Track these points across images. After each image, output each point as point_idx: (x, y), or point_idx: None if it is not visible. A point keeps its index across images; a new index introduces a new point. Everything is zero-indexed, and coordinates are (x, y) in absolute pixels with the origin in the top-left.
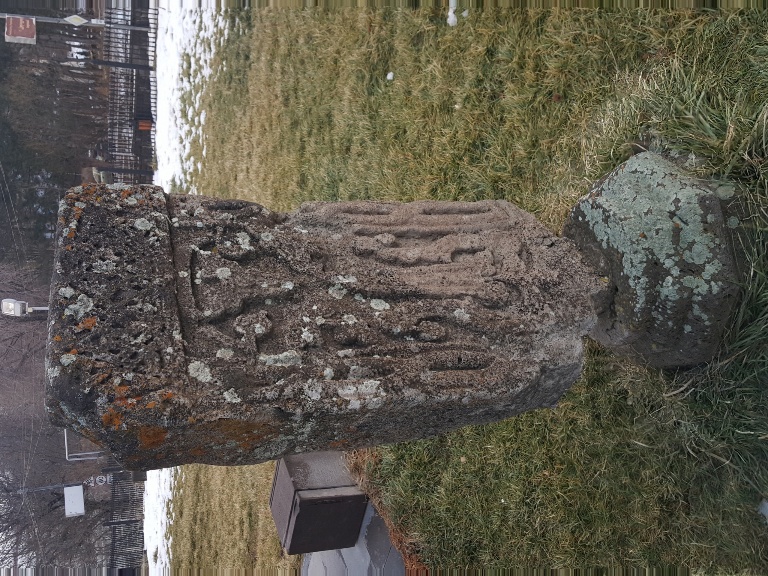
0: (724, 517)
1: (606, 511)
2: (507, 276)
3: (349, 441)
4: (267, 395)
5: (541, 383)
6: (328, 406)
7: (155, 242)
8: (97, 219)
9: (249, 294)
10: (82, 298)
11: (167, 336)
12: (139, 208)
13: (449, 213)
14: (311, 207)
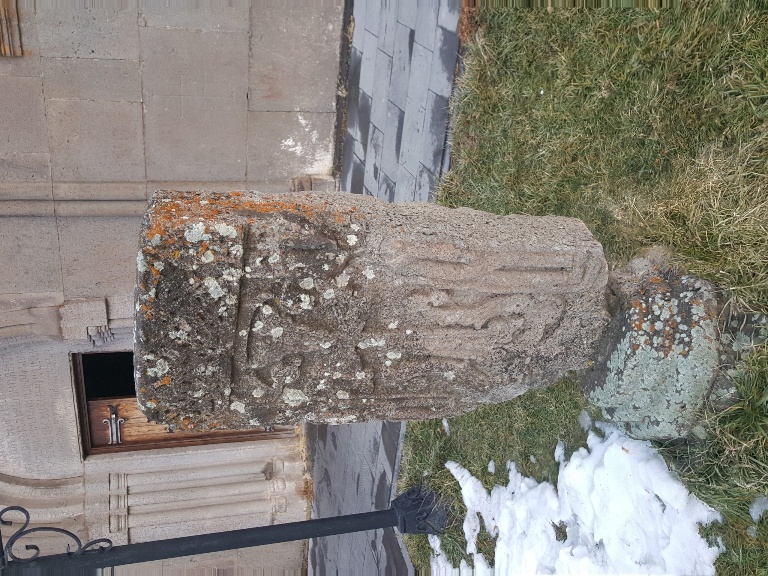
0: None
1: None
2: None
3: None
4: None
5: None
6: None
7: (224, 313)
8: (174, 285)
9: (291, 352)
10: (160, 362)
11: (220, 393)
12: (215, 263)
13: None
14: (390, 253)
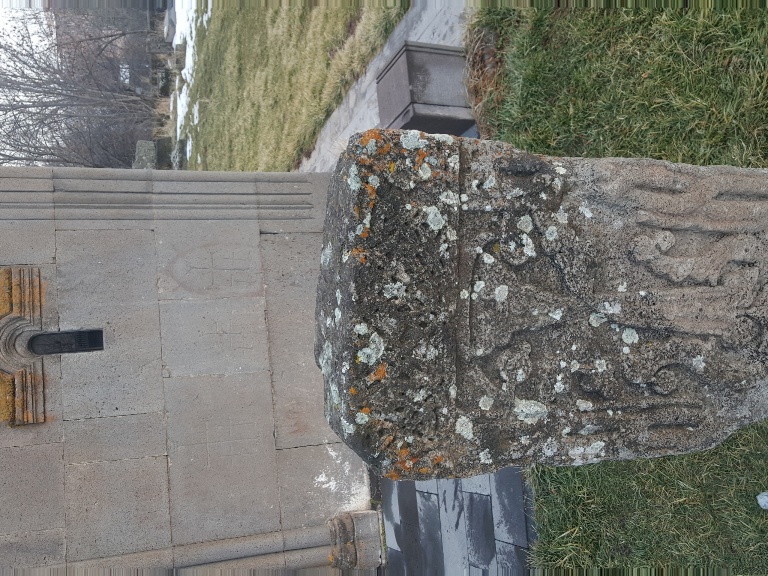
0: None
1: None
2: (760, 313)
3: None
4: (513, 457)
5: None
6: (557, 464)
7: (445, 253)
8: (391, 210)
9: (520, 326)
10: (374, 338)
11: (444, 393)
12: (432, 183)
13: (742, 195)
14: (605, 177)
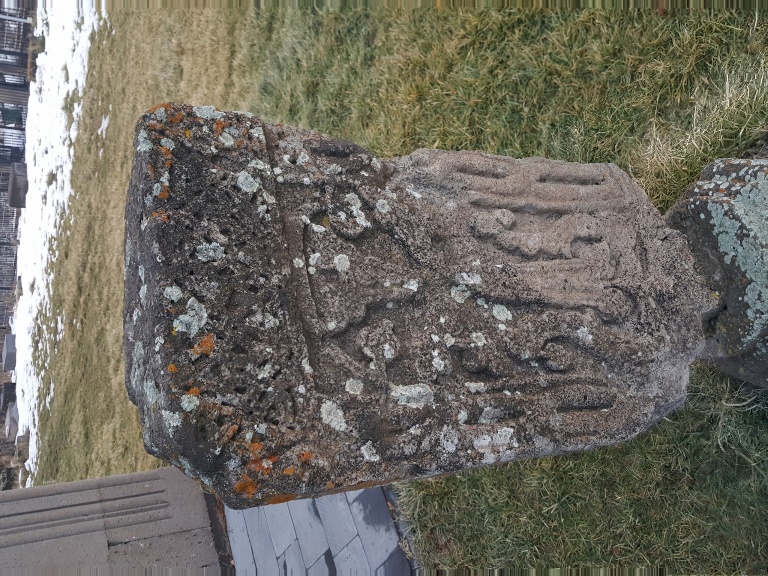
0: (730, 504)
1: (599, 452)
2: (626, 283)
3: None
4: (406, 450)
5: None
6: (463, 461)
7: (265, 214)
8: (192, 171)
9: (373, 297)
10: (192, 304)
11: (297, 367)
12: (236, 151)
13: (563, 180)
14: (424, 160)
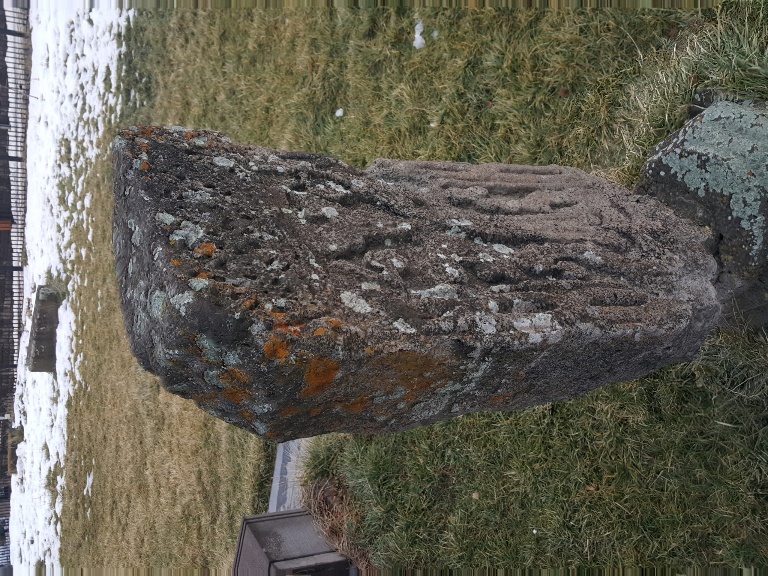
0: None
1: (678, 512)
2: (615, 225)
3: (509, 396)
4: (442, 325)
5: (692, 325)
6: (509, 339)
7: (245, 177)
8: (168, 153)
9: (368, 232)
10: (186, 224)
11: (305, 263)
12: (208, 149)
13: None
14: (387, 162)
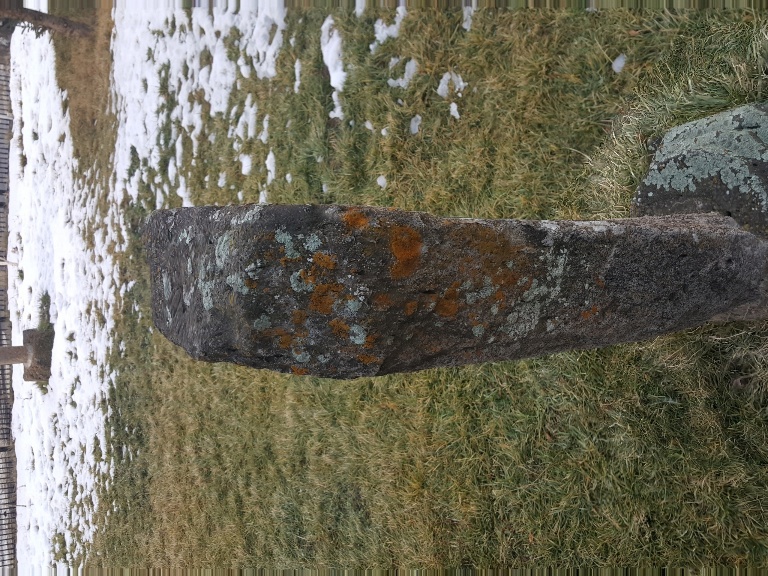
0: None
1: None
2: None
3: (598, 314)
4: None
5: (741, 246)
6: (575, 228)
7: None
8: None
9: None
10: None
11: None
12: None
13: None
14: None
